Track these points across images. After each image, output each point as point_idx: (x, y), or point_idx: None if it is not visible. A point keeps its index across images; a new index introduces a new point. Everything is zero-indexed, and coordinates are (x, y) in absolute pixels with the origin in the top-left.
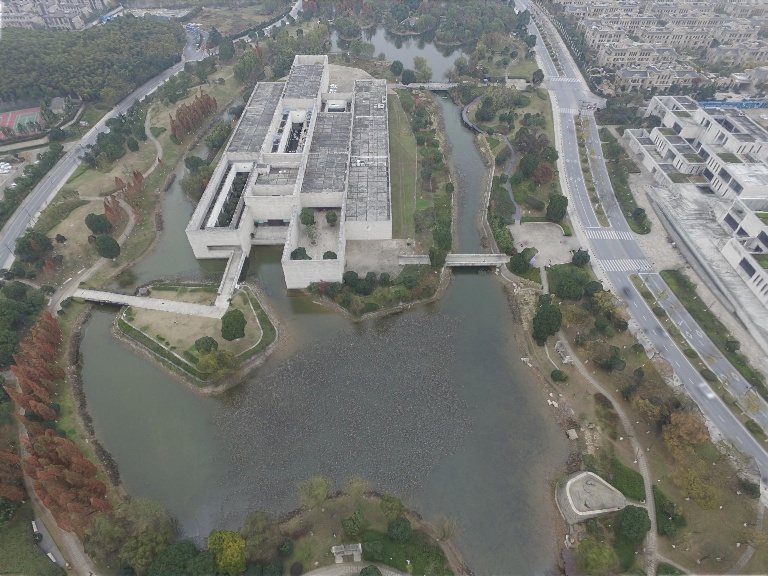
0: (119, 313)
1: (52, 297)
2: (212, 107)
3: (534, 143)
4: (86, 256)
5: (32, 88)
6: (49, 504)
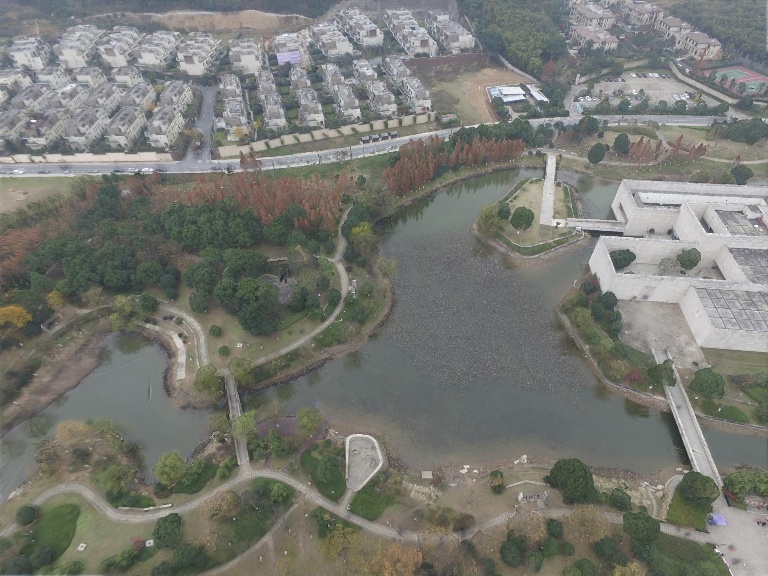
0: None
1: (546, 148)
2: None
3: None
4: None
5: None
6: (394, 169)
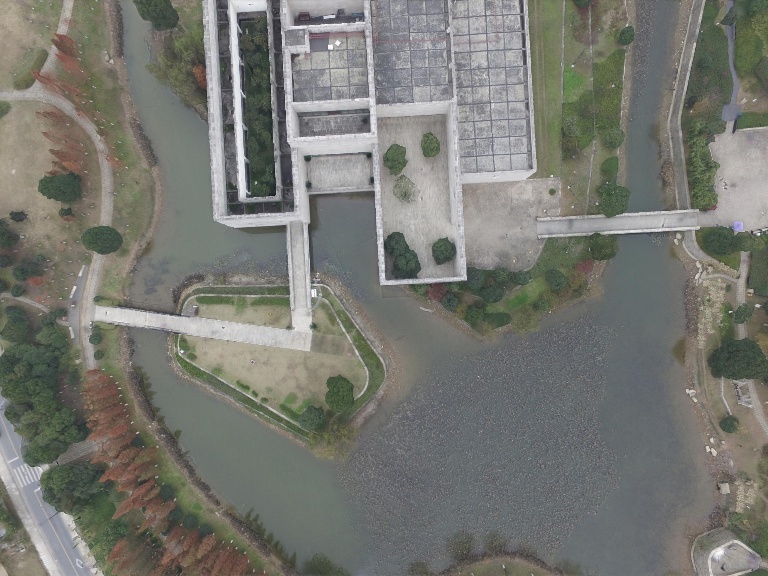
0: (170, 340)
1: (69, 322)
2: None
3: None
4: (73, 243)
5: None
6: None
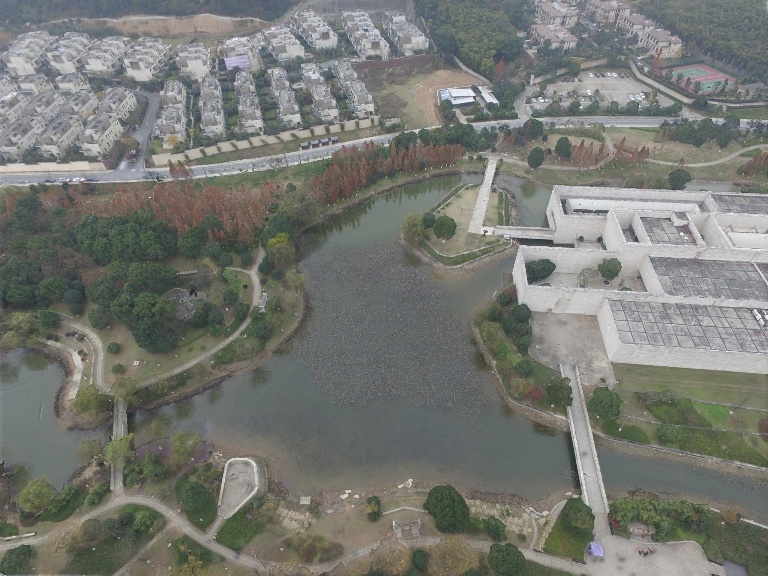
0: None
1: (488, 152)
2: None
3: None
4: None
5: (763, 66)
6: None
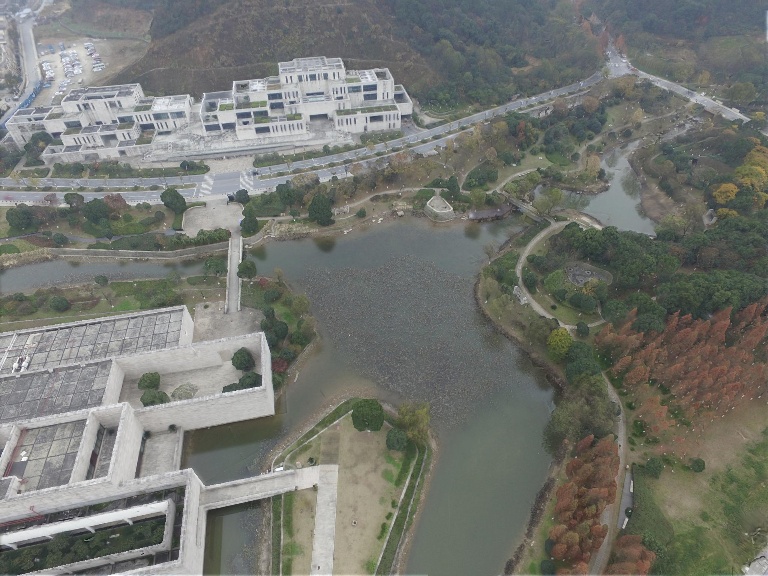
0: None
1: None
2: None
3: (36, 213)
4: None
5: None
6: None
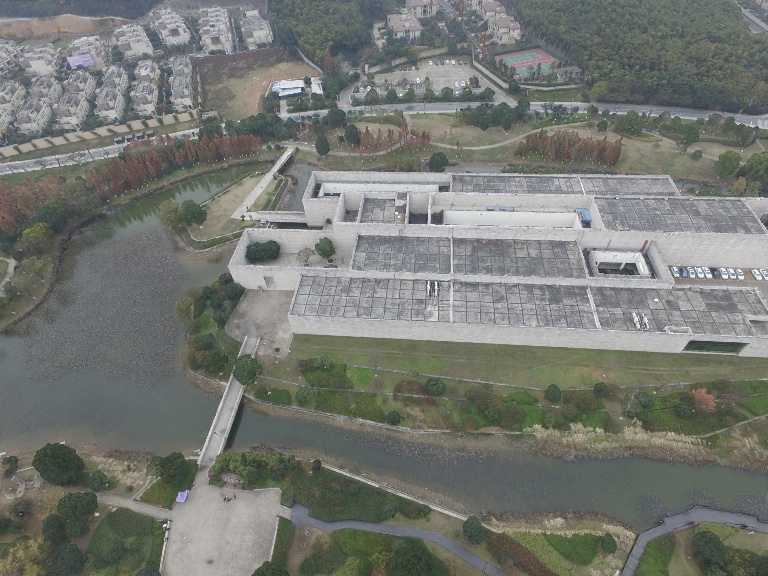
0: None
1: (290, 142)
2: (618, 161)
3: None
4: None
5: None
6: None
